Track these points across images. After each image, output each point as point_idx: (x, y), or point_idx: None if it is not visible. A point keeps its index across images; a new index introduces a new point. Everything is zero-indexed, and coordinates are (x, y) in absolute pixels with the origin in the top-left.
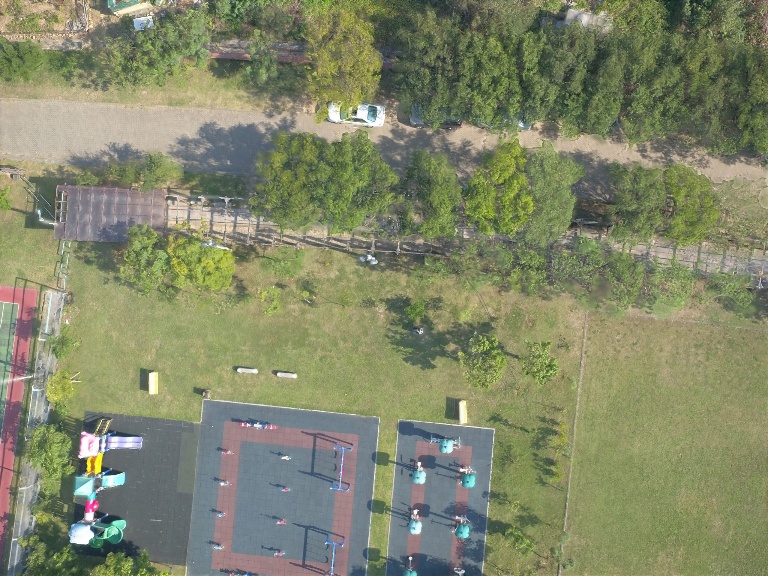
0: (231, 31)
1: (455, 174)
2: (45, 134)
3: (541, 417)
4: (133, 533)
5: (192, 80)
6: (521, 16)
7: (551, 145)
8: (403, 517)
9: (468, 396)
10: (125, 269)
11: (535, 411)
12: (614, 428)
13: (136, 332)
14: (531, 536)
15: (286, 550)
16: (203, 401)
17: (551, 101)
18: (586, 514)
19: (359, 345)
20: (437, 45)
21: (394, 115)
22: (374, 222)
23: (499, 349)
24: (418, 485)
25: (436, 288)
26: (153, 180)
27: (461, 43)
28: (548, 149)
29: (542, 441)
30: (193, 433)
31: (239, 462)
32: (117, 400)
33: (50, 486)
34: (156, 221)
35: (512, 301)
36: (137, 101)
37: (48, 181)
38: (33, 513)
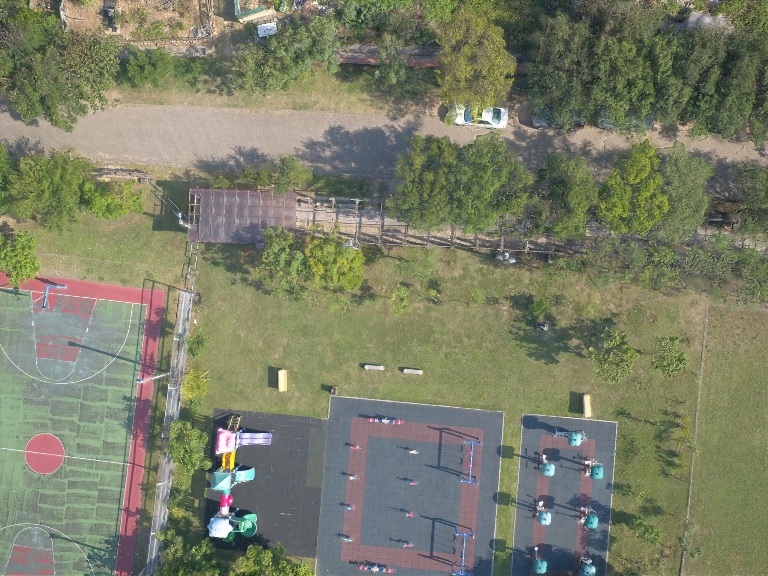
0: (354, 36)
1: (592, 174)
2: (171, 139)
3: (663, 410)
4: (263, 527)
5: (316, 84)
6: (649, 19)
7: (683, 145)
8: (528, 509)
9: (591, 390)
10: (260, 270)
11: (657, 404)
12: (735, 420)
13: (263, 331)
14: (654, 526)
15: (414, 542)
16: (330, 398)
17: (684, 102)
18: (708, 504)
19: (483, 342)
20: (571, 49)
21: (516, 117)
22: (506, 222)
23: (628, 344)
24: (543, 477)
25: (558, 285)
26: (285, 183)
27: (596, 46)
28: (681, 149)
29: (664, 433)
30: (321, 429)
31: (367, 457)
32: (246, 397)
33: (185, 482)
34: (288, 223)
35: (633, 297)
36: (262, 106)
37: (175, 184)
38: (170, 508)
